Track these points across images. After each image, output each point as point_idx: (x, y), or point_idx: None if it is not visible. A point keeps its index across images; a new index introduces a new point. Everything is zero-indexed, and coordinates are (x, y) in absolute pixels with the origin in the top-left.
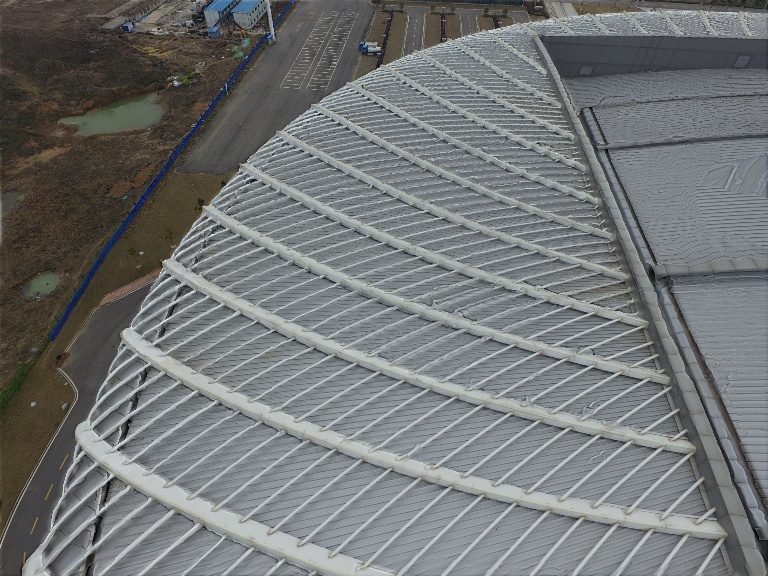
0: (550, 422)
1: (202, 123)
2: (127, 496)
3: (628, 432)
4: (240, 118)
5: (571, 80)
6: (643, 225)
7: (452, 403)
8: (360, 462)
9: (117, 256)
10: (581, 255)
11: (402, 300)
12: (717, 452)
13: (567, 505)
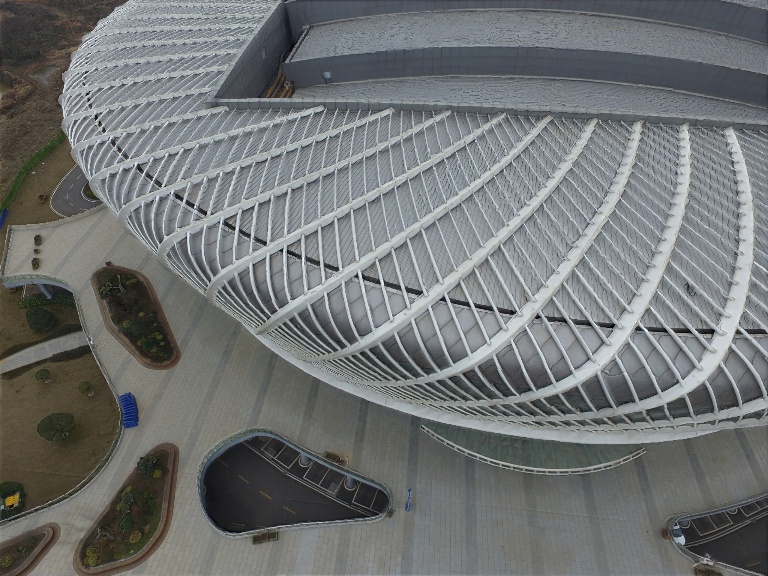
0: None
1: None
2: None
3: None
4: None
5: None
6: None
7: None
8: None
9: None
10: None
11: None
12: None
13: None
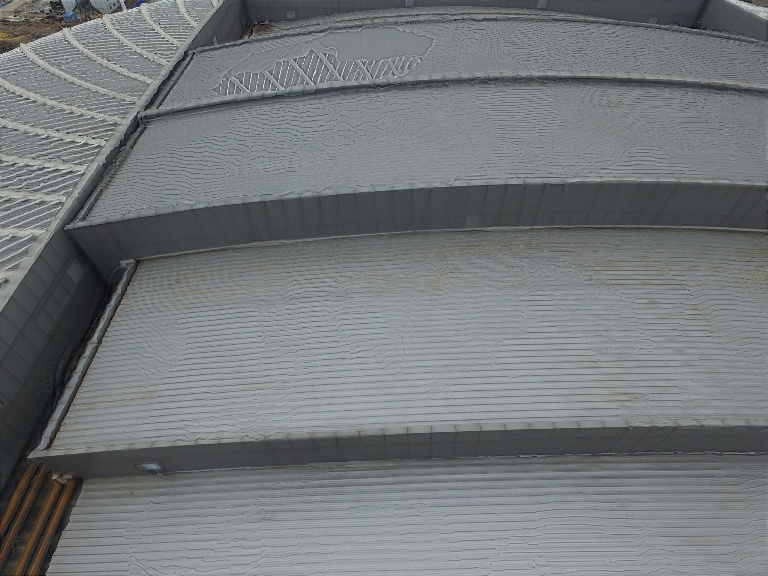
0: None
1: None
2: None
3: None
4: None
5: (280, 23)
6: (172, 94)
7: None
8: None
9: None
10: (112, 114)
11: None
12: (75, 194)
13: None
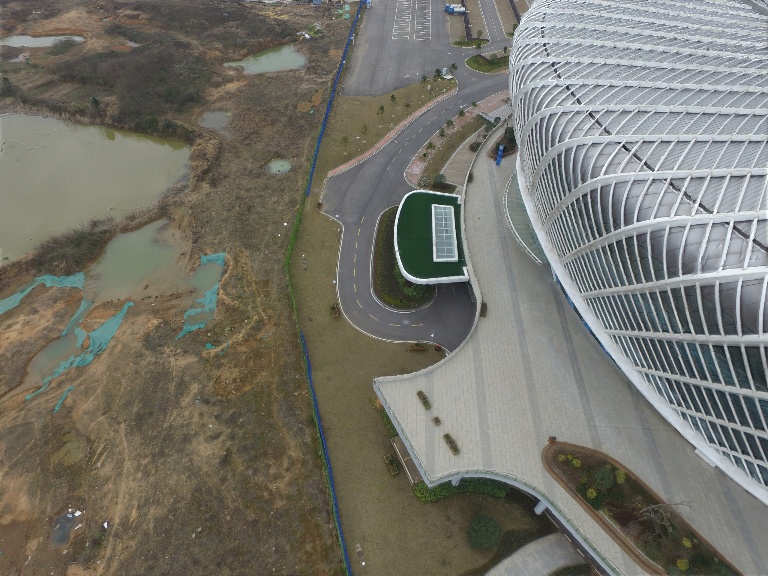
0: None
1: (343, 63)
2: (606, 113)
3: None
4: (372, 60)
5: None
6: None
7: None
8: (713, 91)
9: (327, 147)
10: None
11: (693, 49)
12: None
13: None
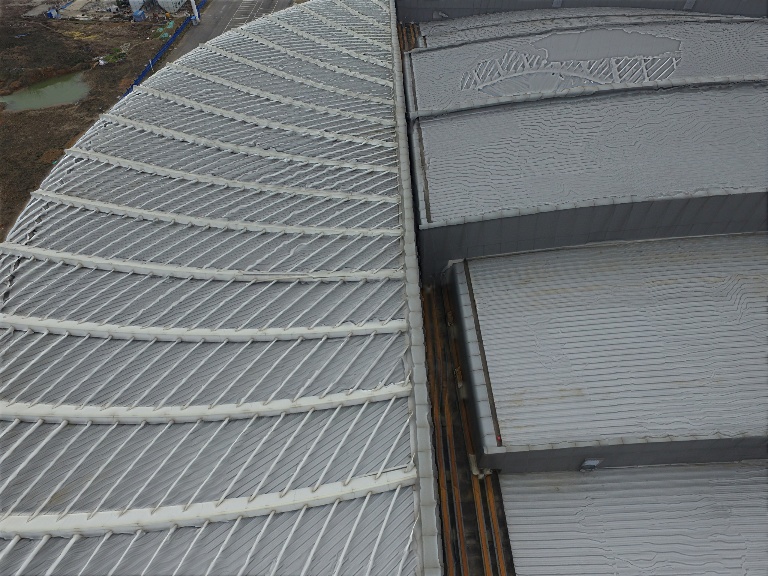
0: (316, 194)
1: None
2: (32, 263)
3: (364, 195)
4: None
5: (426, 24)
6: (418, 95)
7: (258, 194)
8: (190, 226)
9: None
10: (370, 114)
11: (234, 145)
12: (409, 194)
13: (314, 228)
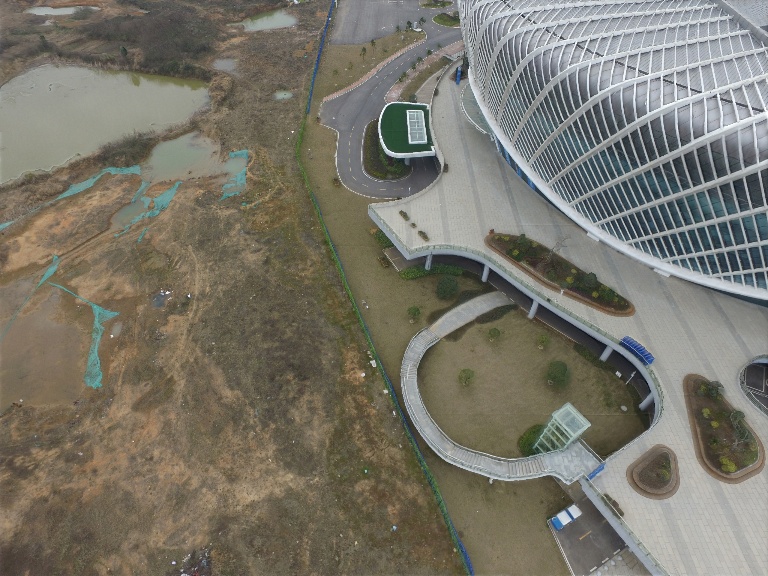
0: None
1: (329, 22)
2: None
3: None
4: (353, 19)
5: None
6: None
7: None
8: None
9: (320, 81)
10: None
11: None
12: None
13: None
